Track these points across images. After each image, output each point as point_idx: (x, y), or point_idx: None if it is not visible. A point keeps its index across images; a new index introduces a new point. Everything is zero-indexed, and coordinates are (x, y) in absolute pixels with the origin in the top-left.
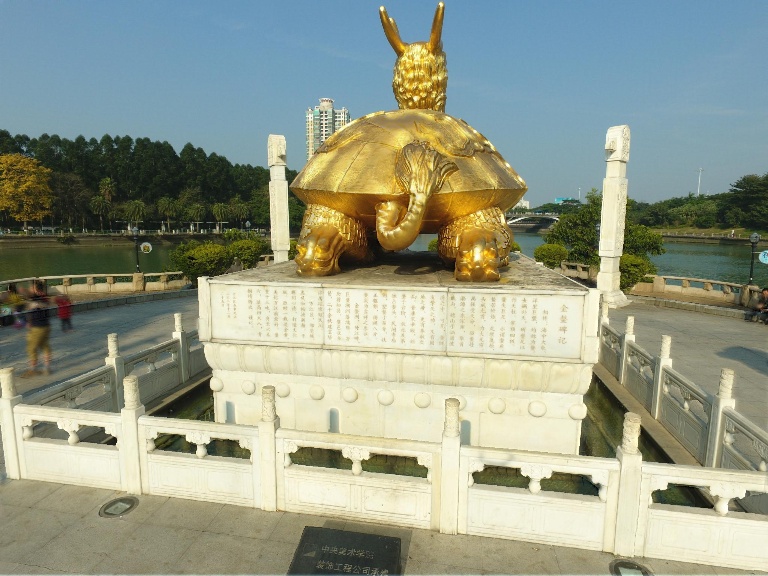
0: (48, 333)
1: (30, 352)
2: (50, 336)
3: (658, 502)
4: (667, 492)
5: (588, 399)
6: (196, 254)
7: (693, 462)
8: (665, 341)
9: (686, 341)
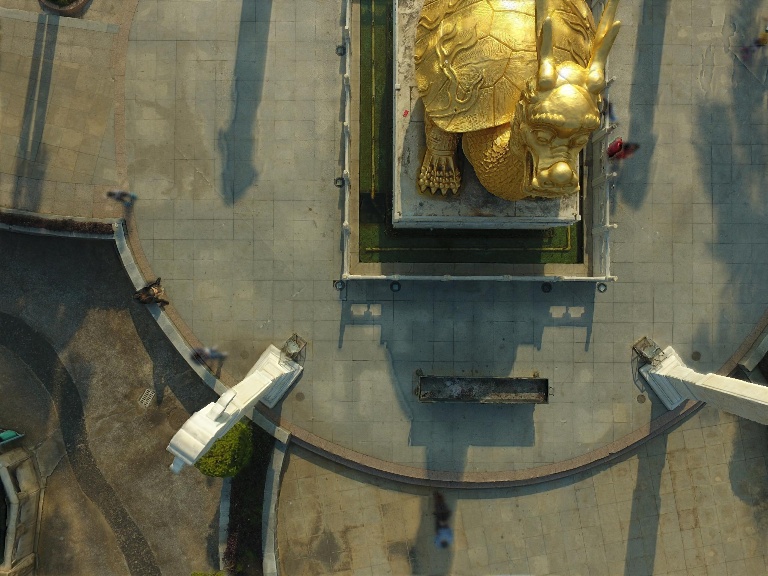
0: (765, 135)
1: (730, 88)
2: (756, 127)
3: (370, 6)
4: (364, 13)
5: (367, 102)
6: None
7: (354, 10)
8: (348, 27)
9: (266, 205)
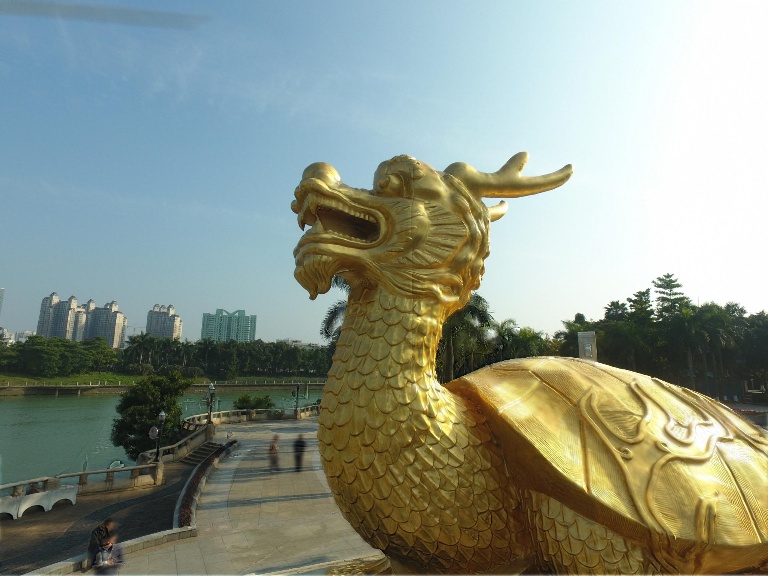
0: None
1: None
2: None
3: None
4: None
5: None
6: None
7: None
8: None
9: None
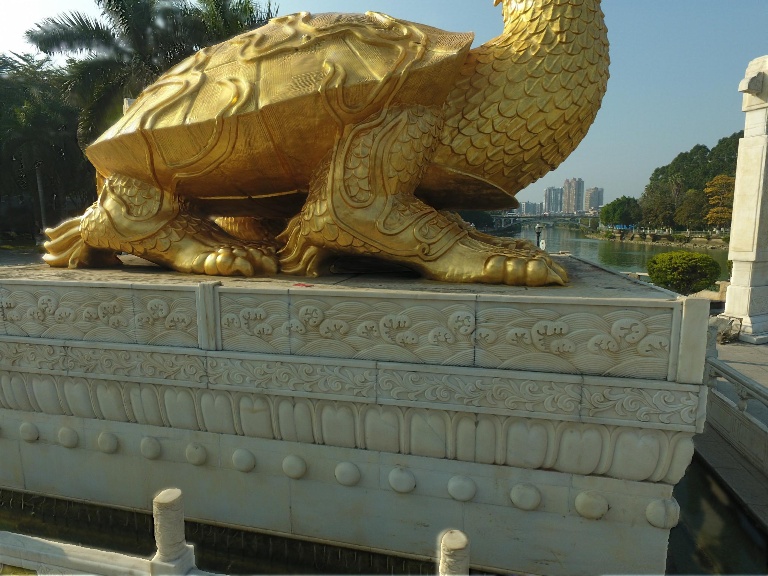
0: None
1: None
2: None
3: None
4: None
5: None
6: (660, 257)
7: None
8: None
9: None
